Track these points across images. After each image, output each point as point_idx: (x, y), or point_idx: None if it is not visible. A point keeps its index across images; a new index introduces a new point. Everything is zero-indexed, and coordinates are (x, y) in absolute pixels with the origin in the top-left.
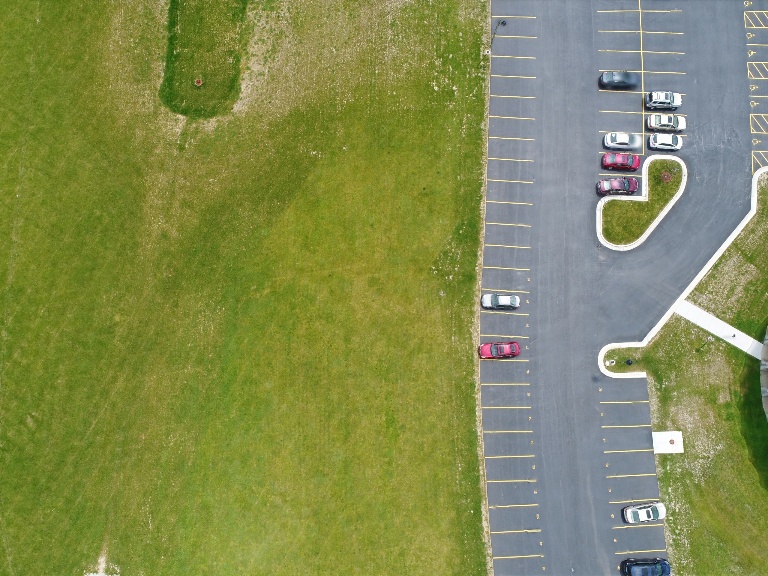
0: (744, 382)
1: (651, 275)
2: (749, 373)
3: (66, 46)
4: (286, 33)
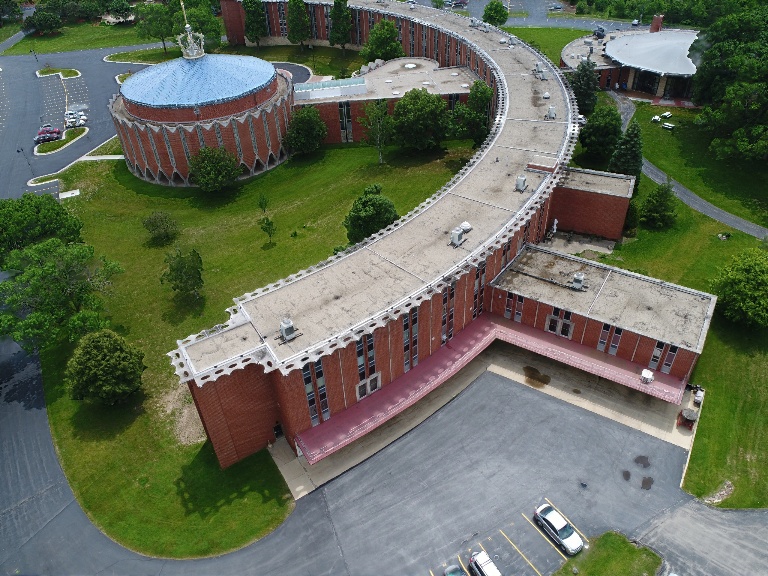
0: (117, 166)
1: None
2: (120, 163)
3: None
4: None
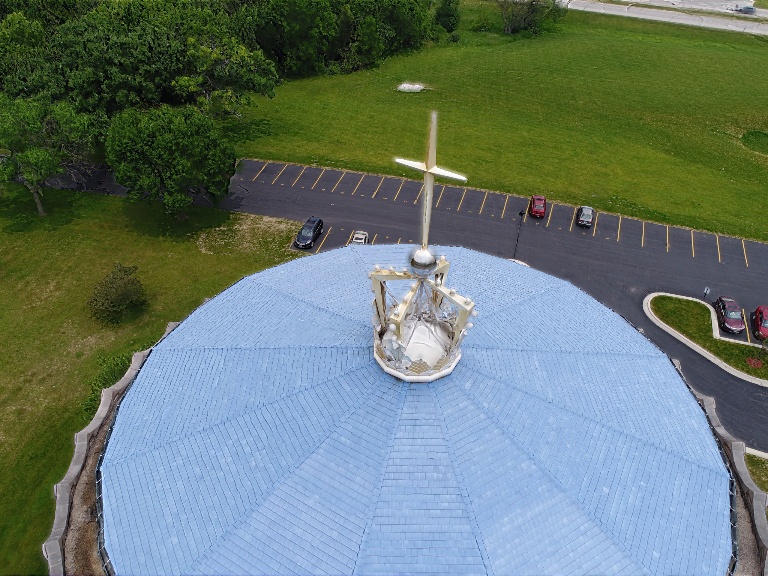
0: None
1: None
2: None
3: None
4: None
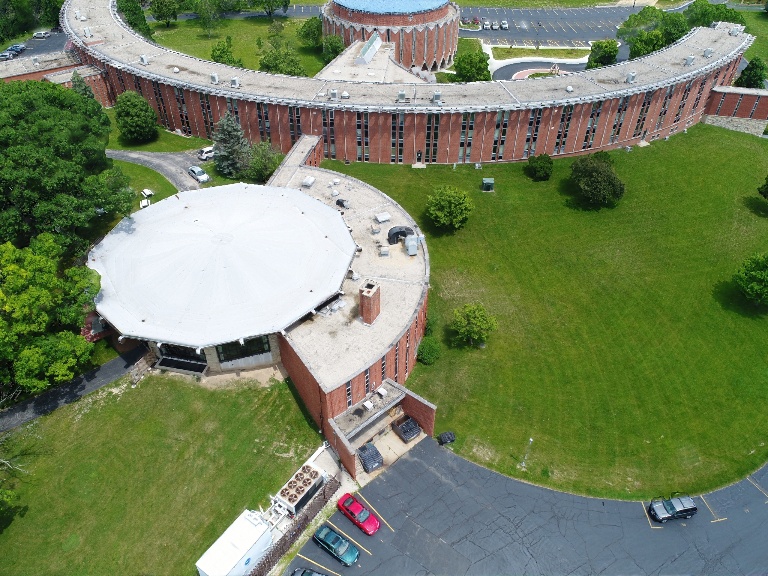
0: None
1: None
2: None
3: None
4: None
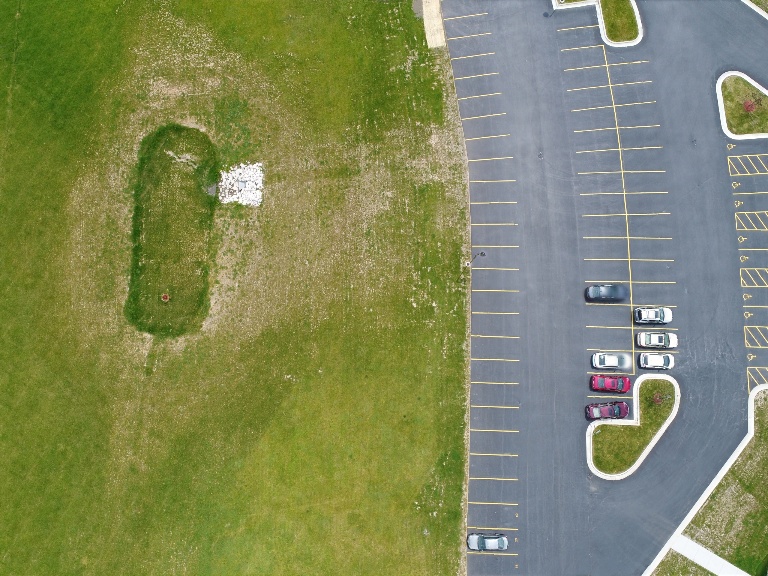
0: None
1: (645, 507)
2: None
3: (25, 263)
4: (256, 244)
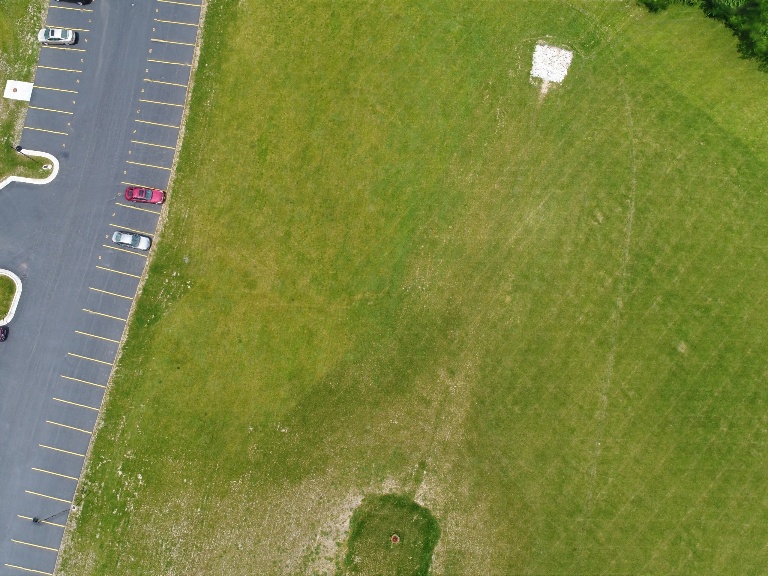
0: None
1: None
2: None
3: None
4: None
